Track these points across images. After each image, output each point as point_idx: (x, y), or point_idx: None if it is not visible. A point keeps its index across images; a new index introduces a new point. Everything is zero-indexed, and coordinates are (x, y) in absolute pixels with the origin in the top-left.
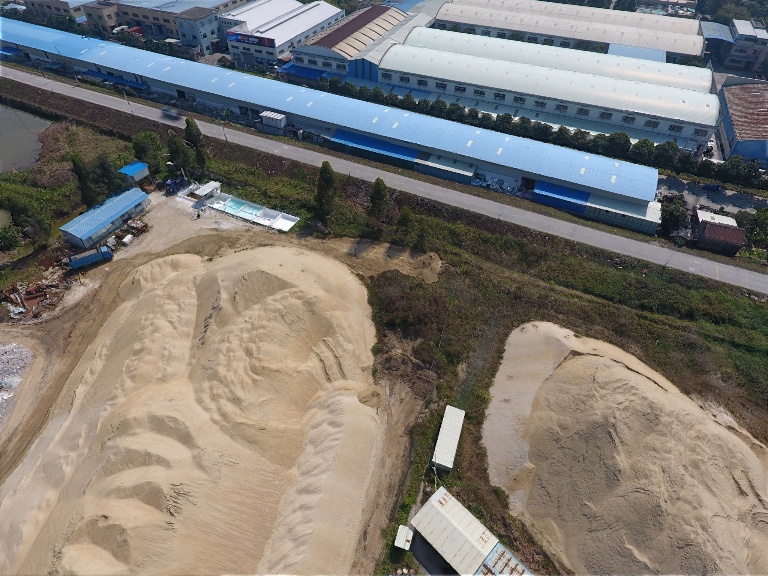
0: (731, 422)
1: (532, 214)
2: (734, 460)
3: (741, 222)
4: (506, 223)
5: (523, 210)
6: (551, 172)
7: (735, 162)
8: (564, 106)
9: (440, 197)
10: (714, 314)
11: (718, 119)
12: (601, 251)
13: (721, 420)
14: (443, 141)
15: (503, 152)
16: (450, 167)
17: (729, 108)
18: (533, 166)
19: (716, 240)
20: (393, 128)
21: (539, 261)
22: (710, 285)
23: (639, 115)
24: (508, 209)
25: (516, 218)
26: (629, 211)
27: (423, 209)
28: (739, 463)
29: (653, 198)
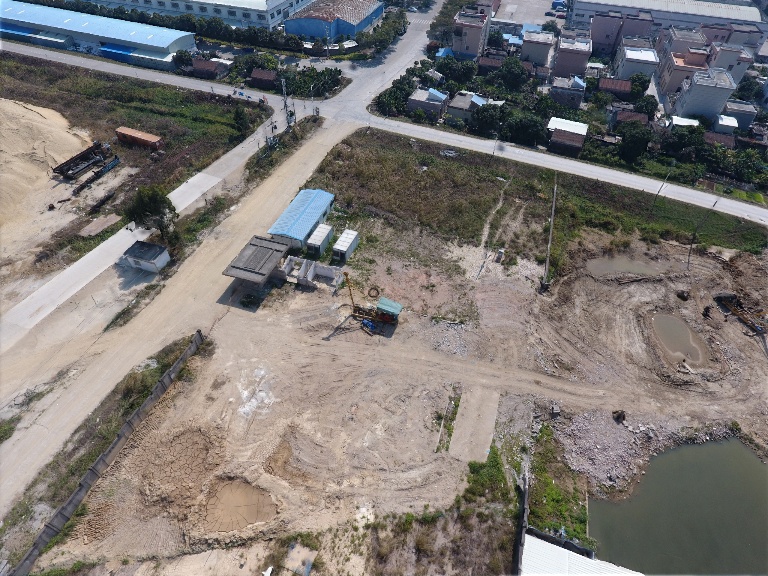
0: (81, 133)
1: (79, 58)
2: (41, 136)
3: (236, 63)
4: (53, 62)
5: (76, 56)
6: (111, 34)
7: (249, 27)
8: (176, 4)
9: (20, 51)
10: (144, 98)
11: (268, 6)
12: (103, 73)
13: (75, 132)
14: (48, 20)
15: (87, 25)
16: (51, 38)
17: (307, 6)
18: (101, 32)
19: (200, 69)
20: (18, 14)
21: (58, 80)
22: (157, 85)
23: (220, 6)
24: (65, 56)
25: (64, 60)
26: (155, 56)
27: (2, 58)
28: (44, 138)
29: (167, 45)
